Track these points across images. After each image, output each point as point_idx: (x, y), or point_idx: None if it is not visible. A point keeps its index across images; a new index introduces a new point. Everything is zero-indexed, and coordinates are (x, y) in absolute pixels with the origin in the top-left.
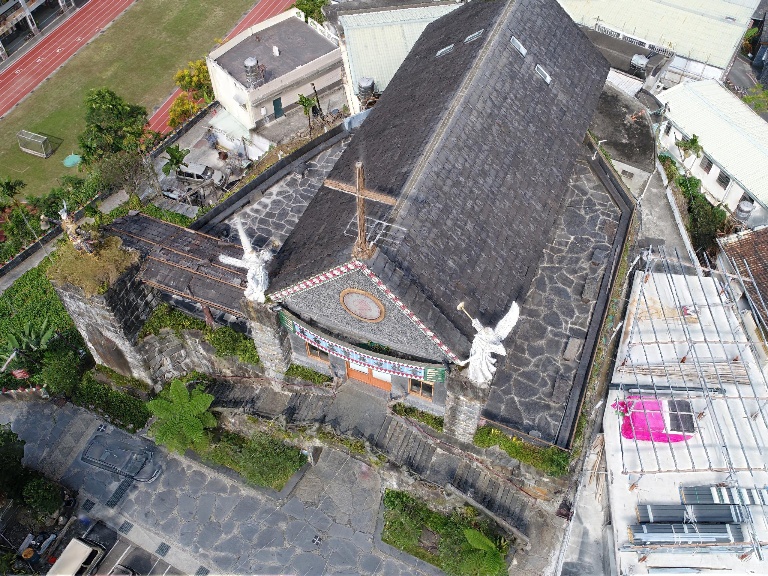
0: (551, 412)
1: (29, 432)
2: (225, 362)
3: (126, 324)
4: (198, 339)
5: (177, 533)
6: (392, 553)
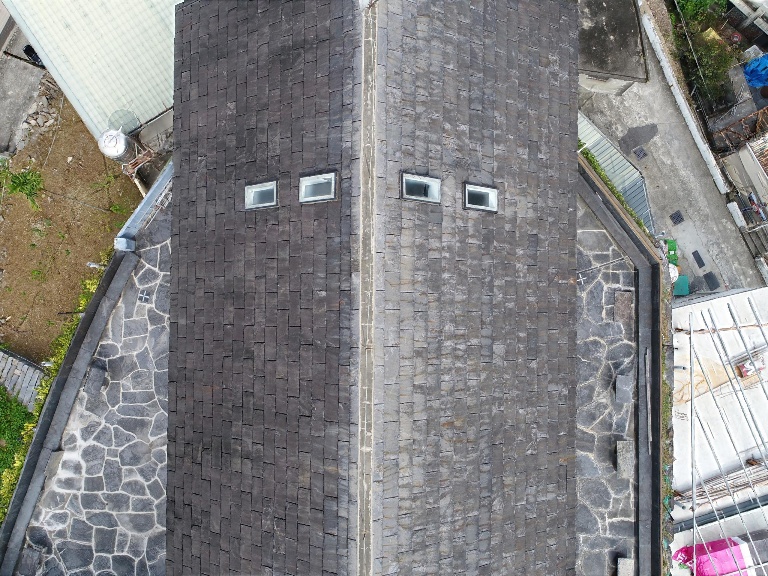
0: None
1: None
2: None
3: None
4: None
5: None
6: None
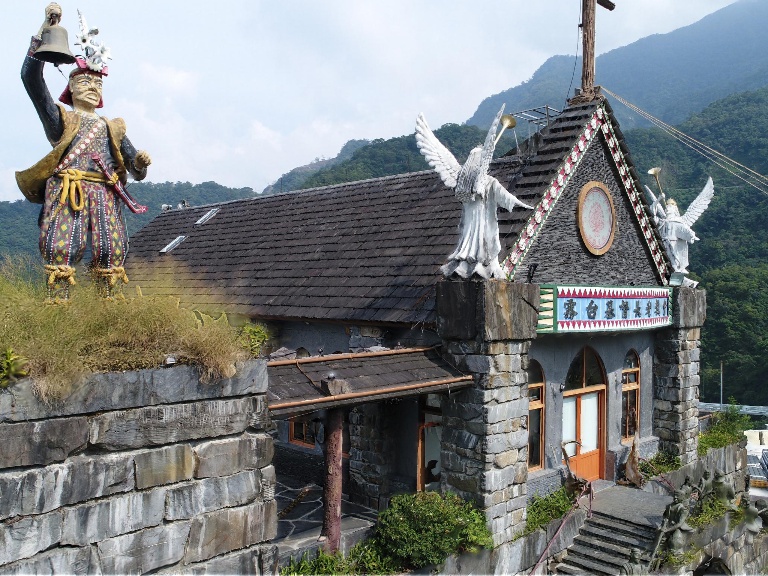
0: None
1: None
2: None
3: None
4: None
5: None
6: None
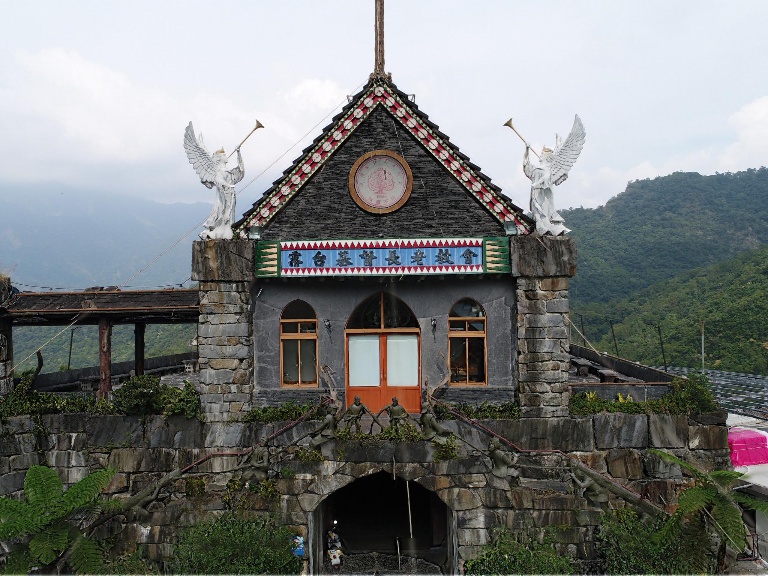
0: None
1: None
2: (126, 455)
3: None
4: (76, 433)
5: None
6: None
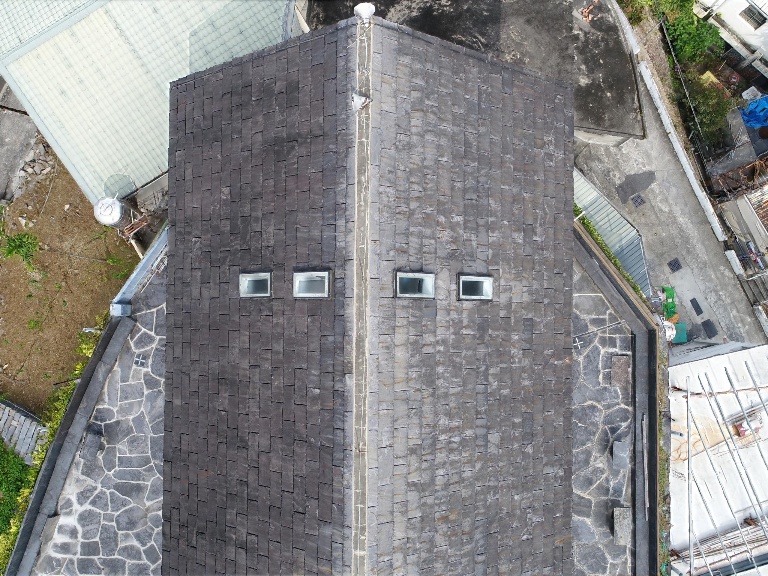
0: None
1: None
2: None
3: None
4: None
5: None
6: None
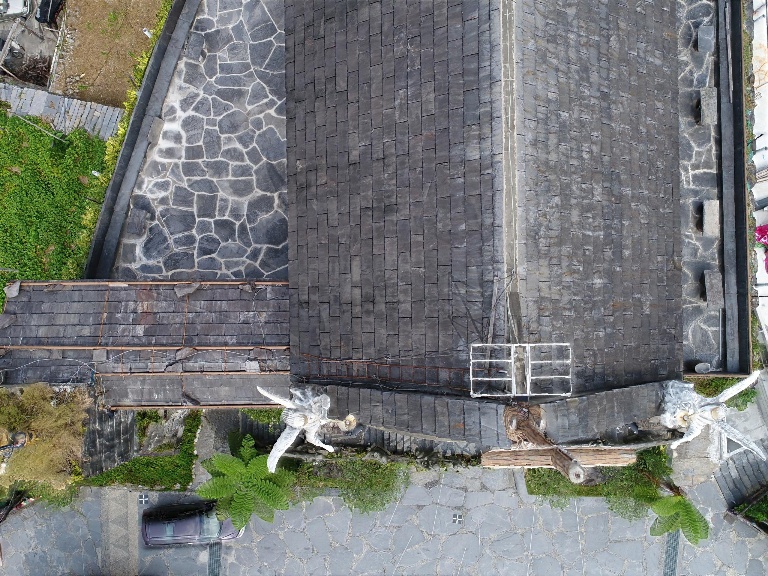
0: (704, 316)
1: (62, 540)
2: None
3: (120, 452)
4: None
5: (305, 575)
6: (545, 503)
